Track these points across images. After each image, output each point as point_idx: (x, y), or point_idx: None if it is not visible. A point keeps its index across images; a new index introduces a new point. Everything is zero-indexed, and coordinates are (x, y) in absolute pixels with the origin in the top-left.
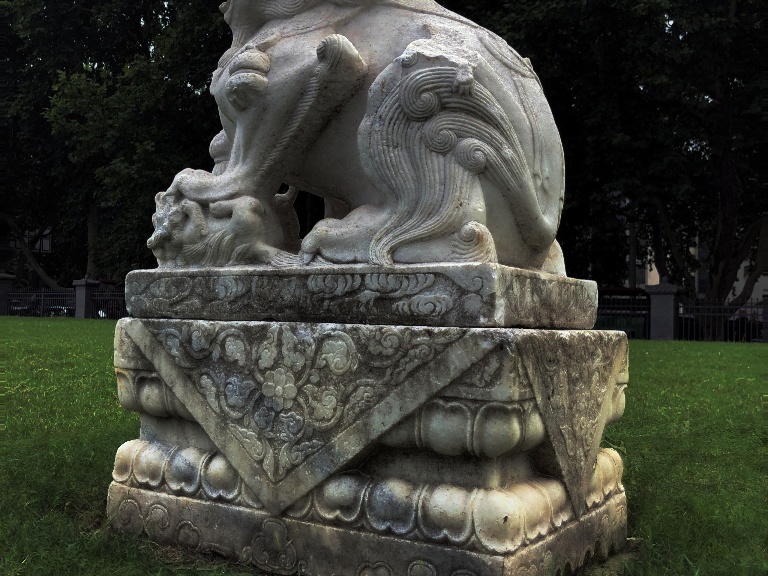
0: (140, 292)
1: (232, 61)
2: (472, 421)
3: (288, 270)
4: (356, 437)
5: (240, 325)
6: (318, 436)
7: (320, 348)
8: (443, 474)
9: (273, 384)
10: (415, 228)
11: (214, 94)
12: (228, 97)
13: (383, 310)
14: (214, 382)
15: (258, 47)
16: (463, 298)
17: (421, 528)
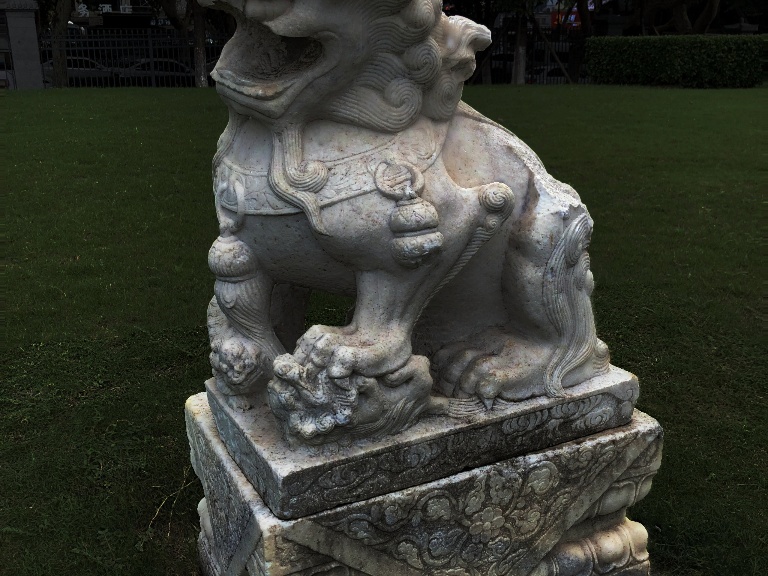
0: (304, 490)
1: (410, 218)
2: (635, 489)
3: (485, 422)
4: (556, 533)
5: (444, 485)
6: (523, 546)
7: (526, 480)
8: (596, 527)
9: (481, 523)
10: (575, 358)
11: (331, 235)
12: (409, 260)
13: (565, 431)
14: (414, 544)
15: (418, 193)
16: (621, 407)
17: (598, 570)
